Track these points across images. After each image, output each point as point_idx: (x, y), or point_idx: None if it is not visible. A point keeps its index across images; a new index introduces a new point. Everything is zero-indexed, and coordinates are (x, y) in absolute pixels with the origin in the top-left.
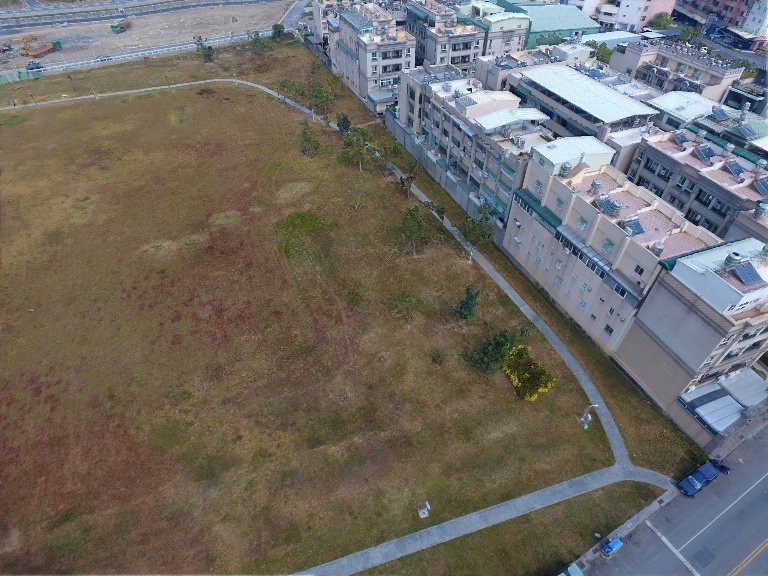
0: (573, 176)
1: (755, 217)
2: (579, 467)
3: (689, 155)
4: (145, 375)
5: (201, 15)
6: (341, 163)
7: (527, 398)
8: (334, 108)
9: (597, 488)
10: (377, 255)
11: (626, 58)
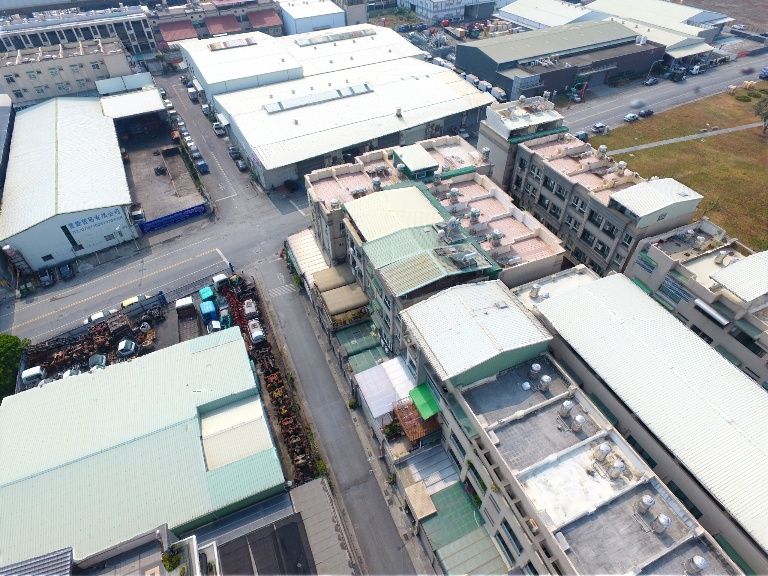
0: None
1: None
2: None
3: None
4: None
5: None
6: None
7: None
8: None
9: None
10: None
11: None
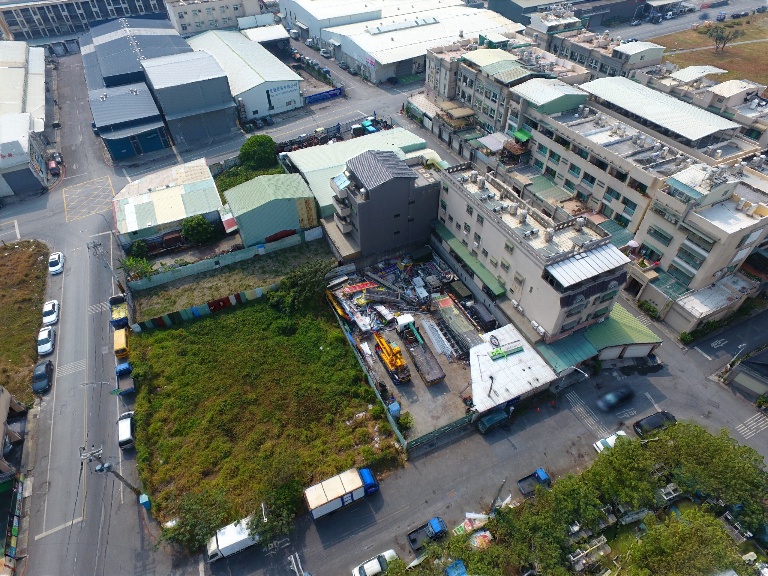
0: None
1: None
2: None
3: None
4: (764, 81)
5: None
6: None
7: None
8: None
9: None
10: None
11: None
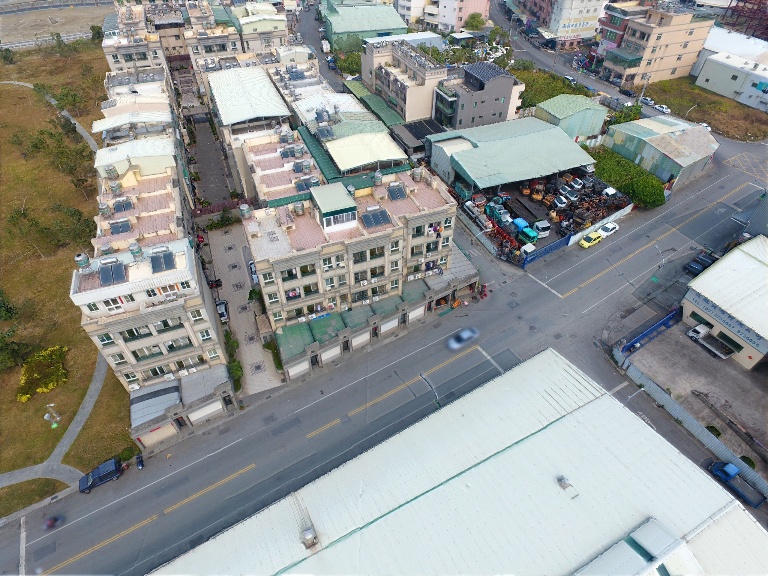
0: (122, 178)
1: (242, 217)
2: (7, 466)
3: (280, 156)
4: None
5: (45, 16)
6: (51, 166)
7: (17, 399)
8: (94, 110)
9: (4, 486)
10: (6, 258)
11: (368, 59)
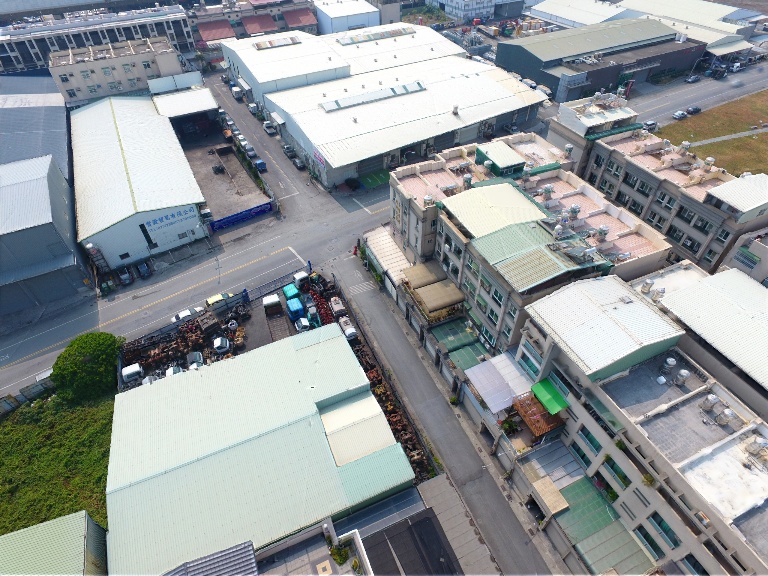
0: None
1: None
2: None
3: None
4: None
5: None
6: None
7: None
8: None
9: None
10: None
11: None
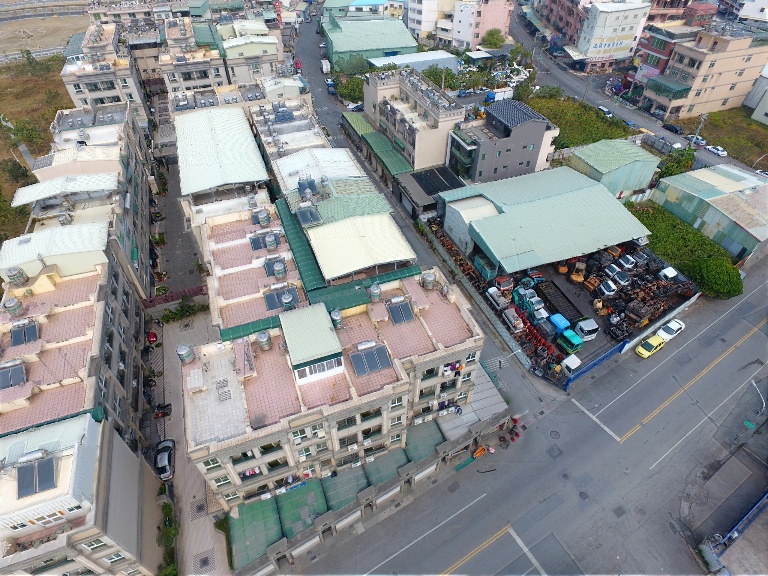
0: (32, 284)
1: None
2: None
3: (250, 243)
4: None
5: (25, 27)
6: None
7: None
8: None
9: None
10: None
11: (371, 91)
